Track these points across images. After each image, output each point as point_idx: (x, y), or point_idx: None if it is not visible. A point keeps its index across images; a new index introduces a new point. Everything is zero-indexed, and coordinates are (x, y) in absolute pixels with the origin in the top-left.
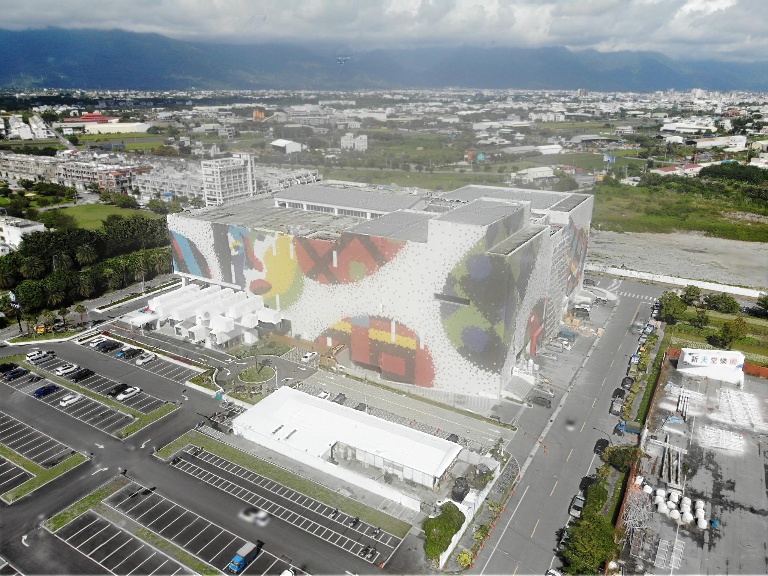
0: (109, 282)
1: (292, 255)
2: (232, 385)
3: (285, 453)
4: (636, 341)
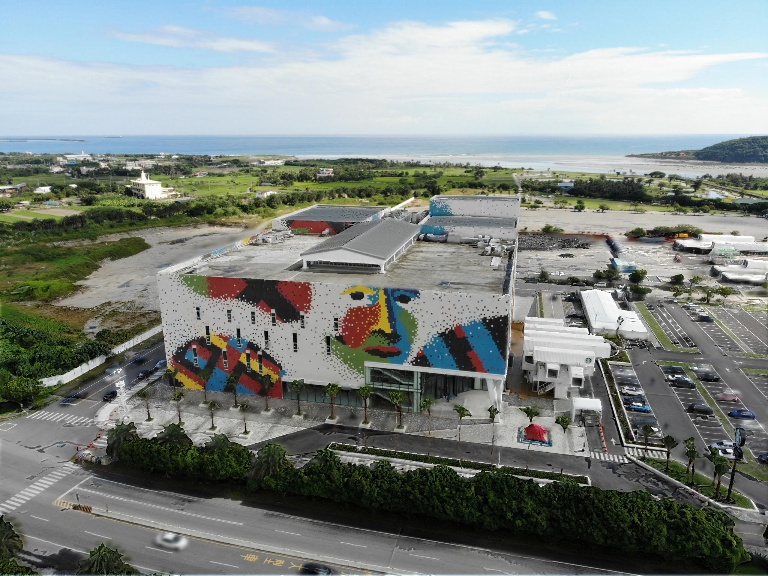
0: None
1: None
2: None
3: None
4: None
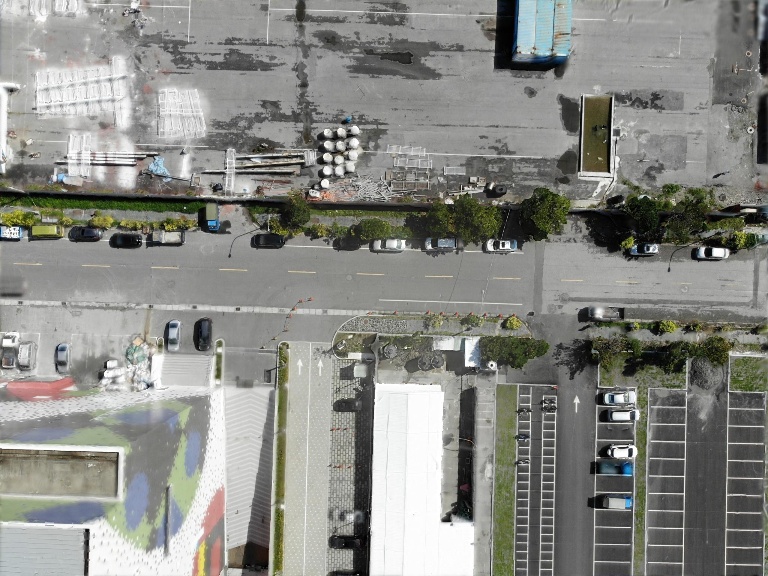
0: None
1: None
2: None
3: None
4: None
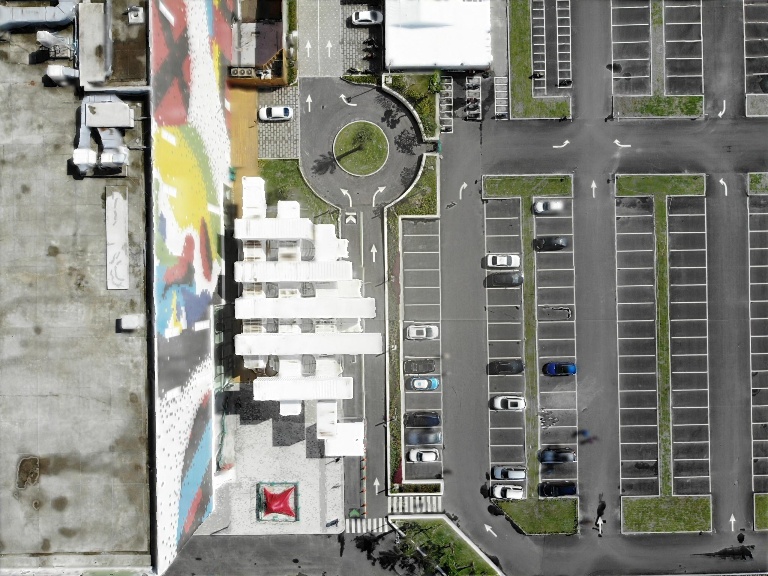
0: None
1: None
2: None
3: None
4: None
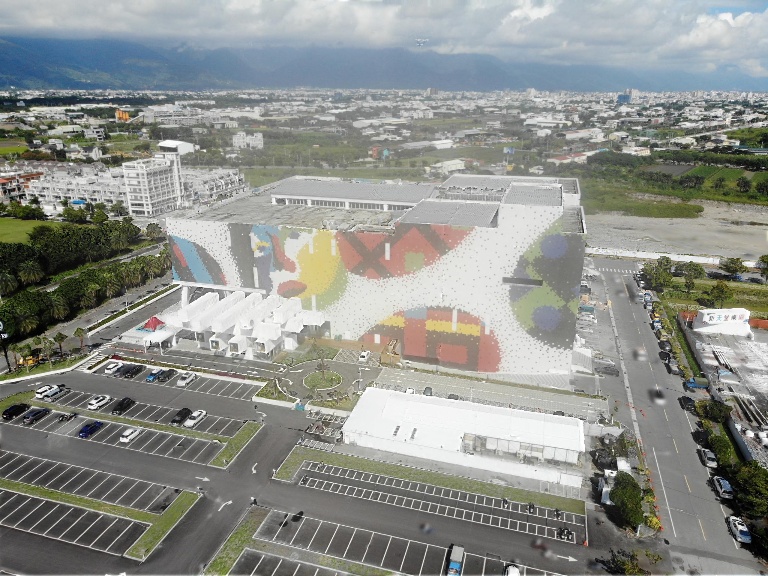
0: (81, 301)
1: (334, 251)
2: (315, 393)
3: (413, 454)
4: (643, 309)
